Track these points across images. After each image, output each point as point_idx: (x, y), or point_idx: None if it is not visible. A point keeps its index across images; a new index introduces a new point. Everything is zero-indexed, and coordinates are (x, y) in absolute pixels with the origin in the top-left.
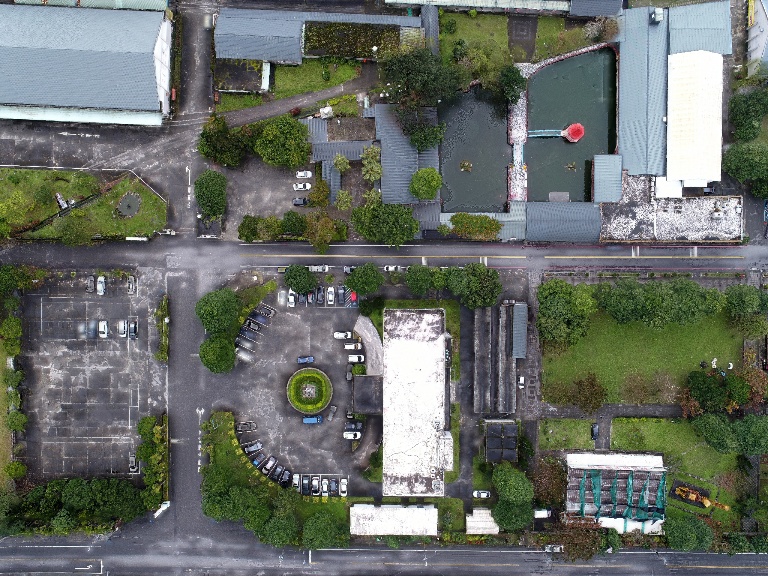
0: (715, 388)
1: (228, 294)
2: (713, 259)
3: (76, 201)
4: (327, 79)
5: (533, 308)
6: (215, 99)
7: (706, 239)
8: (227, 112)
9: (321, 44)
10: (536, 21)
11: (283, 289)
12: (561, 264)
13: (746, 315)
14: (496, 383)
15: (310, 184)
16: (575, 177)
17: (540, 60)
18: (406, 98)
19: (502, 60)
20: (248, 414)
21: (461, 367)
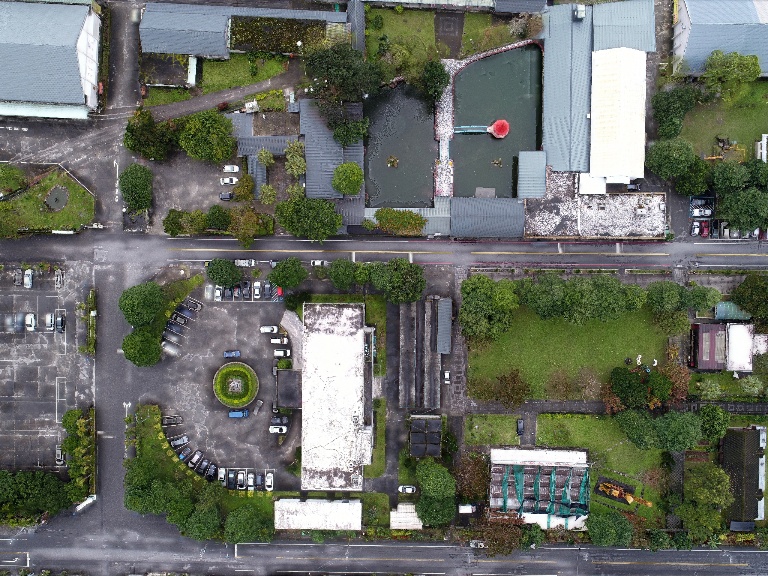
0: (636, 384)
1: (152, 288)
2: (638, 256)
3: (4, 194)
4: (254, 74)
5: (459, 304)
6: (142, 93)
7: (630, 236)
8: (155, 106)
9: (247, 39)
10: (463, 17)
11: (210, 283)
12: (487, 260)
13: (666, 311)
14: (422, 378)
15: (237, 178)
16: (502, 173)
17: (466, 56)
18: (326, 93)
19: (424, 56)
20: (175, 408)
21: (387, 362)
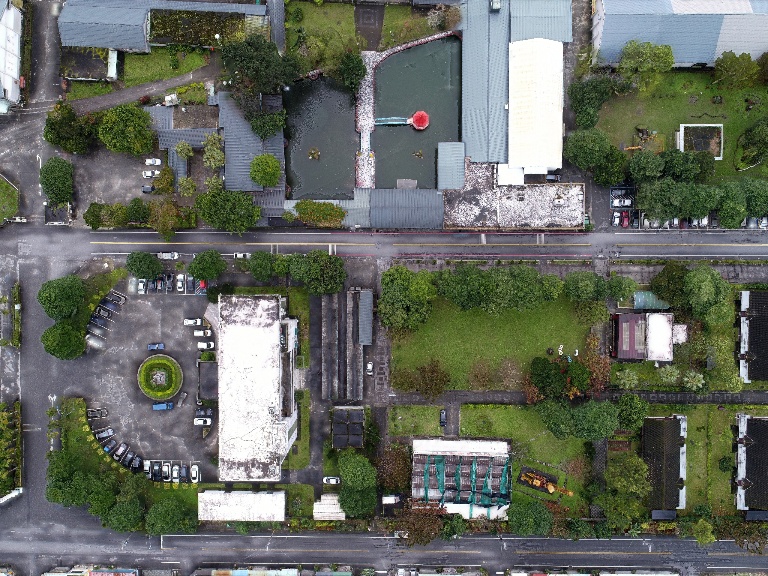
0: (554, 374)
1: (72, 281)
2: (560, 246)
3: None
4: (175, 67)
5: None
6: (63, 87)
7: (549, 226)
8: (77, 100)
9: (166, 32)
10: (383, 9)
11: (134, 276)
12: (409, 251)
13: (583, 301)
14: (345, 370)
15: (159, 172)
16: (423, 165)
17: (387, 48)
18: (240, 85)
19: (340, 48)
20: (100, 401)
21: (311, 354)
